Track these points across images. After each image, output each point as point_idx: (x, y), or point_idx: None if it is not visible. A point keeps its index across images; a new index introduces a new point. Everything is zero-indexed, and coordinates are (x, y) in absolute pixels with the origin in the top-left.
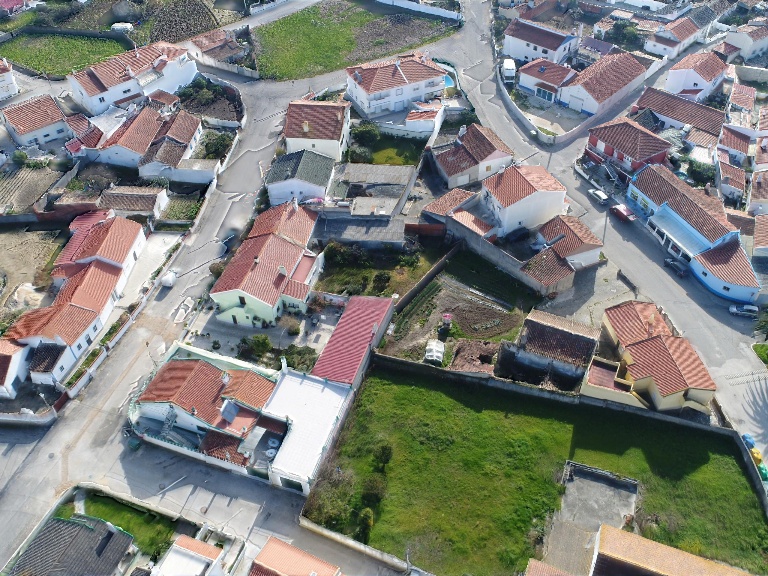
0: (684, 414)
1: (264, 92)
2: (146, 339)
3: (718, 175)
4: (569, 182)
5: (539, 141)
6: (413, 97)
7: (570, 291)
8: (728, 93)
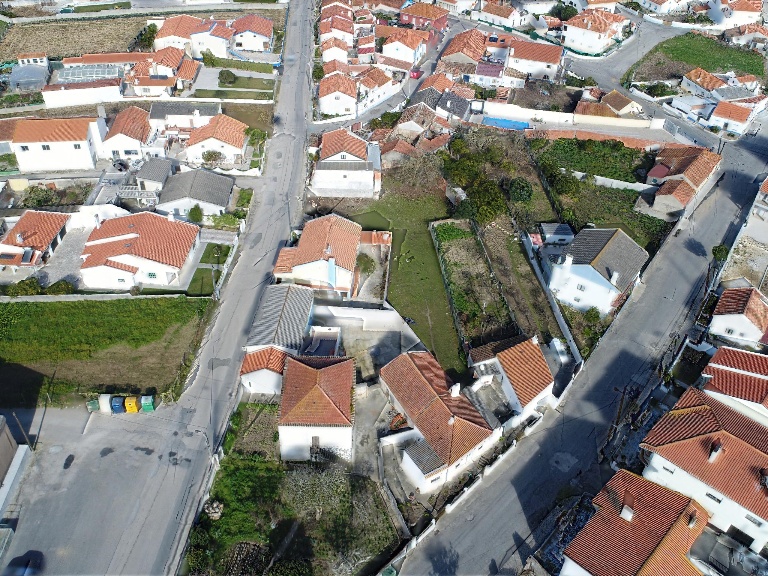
0: None
1: None
2: None
3: None
4: None
5: None
6: None
7: None
8: None
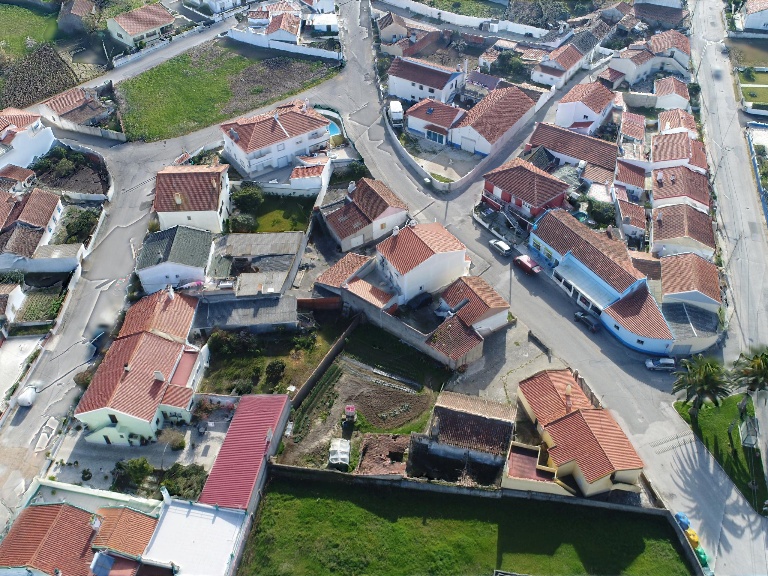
0: (613, 497)
1: (132, 156)
2: (1, 477)
3: (618, 215)
4: (469, 233)
5: (434, 189)
6: (297, 151)
7: (480, 361)
8: (618, 123)
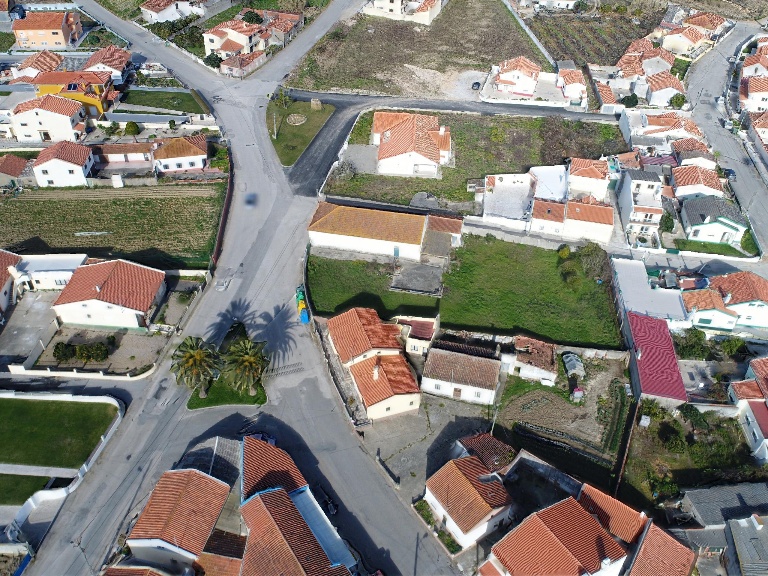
0: None
1: None
2: None
3: None
4: None
5: None
6: None
7: None
8: None
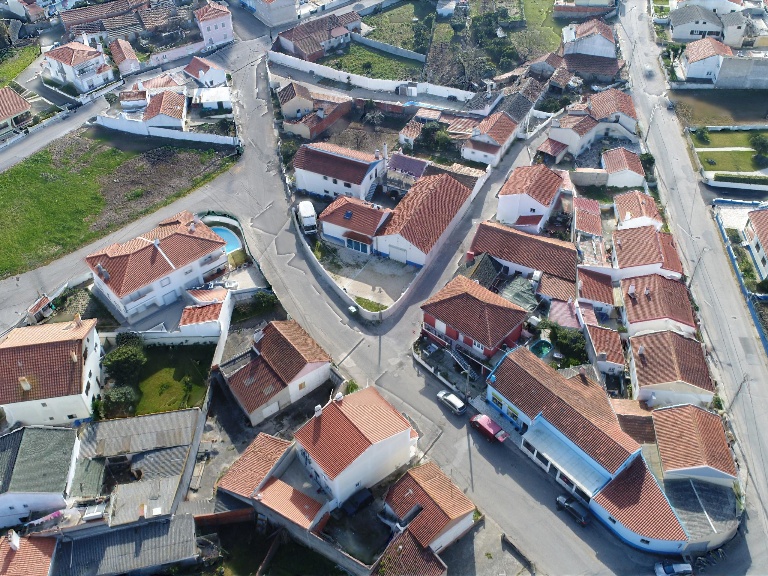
0: None
1: None
2: None
3: (590, 347)
4: (410, 383)
5: (362, 319)
6: (187, 282)
7: None
8: (570, 212)
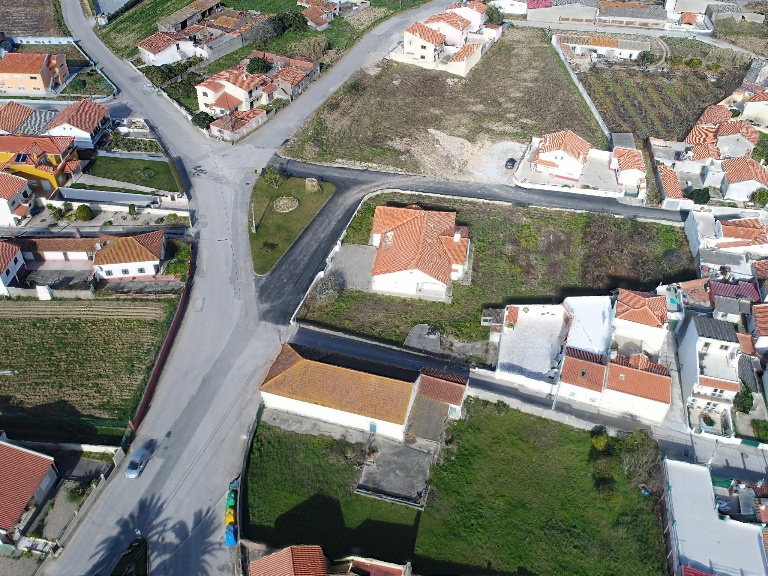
0: None
1: None
2: None
3: None
4: None
5: None
6: None
7: None
8: None
